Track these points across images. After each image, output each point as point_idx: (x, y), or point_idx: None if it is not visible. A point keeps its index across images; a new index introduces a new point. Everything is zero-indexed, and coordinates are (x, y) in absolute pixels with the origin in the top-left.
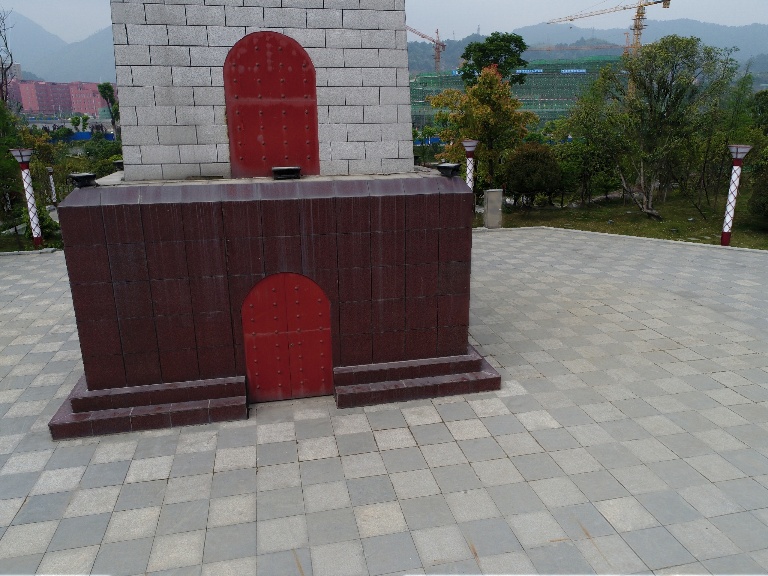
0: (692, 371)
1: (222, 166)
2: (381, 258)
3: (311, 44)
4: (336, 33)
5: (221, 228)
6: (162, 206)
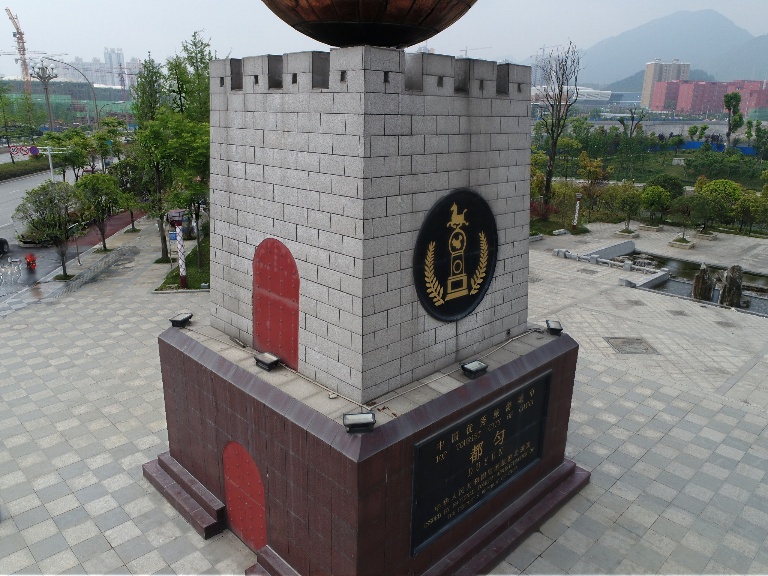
0: None
1: (249, 336)
2: (292, 476)
3: (298, 256)
4: (314, 250)
5: (212, 389)
6: (190, 358)
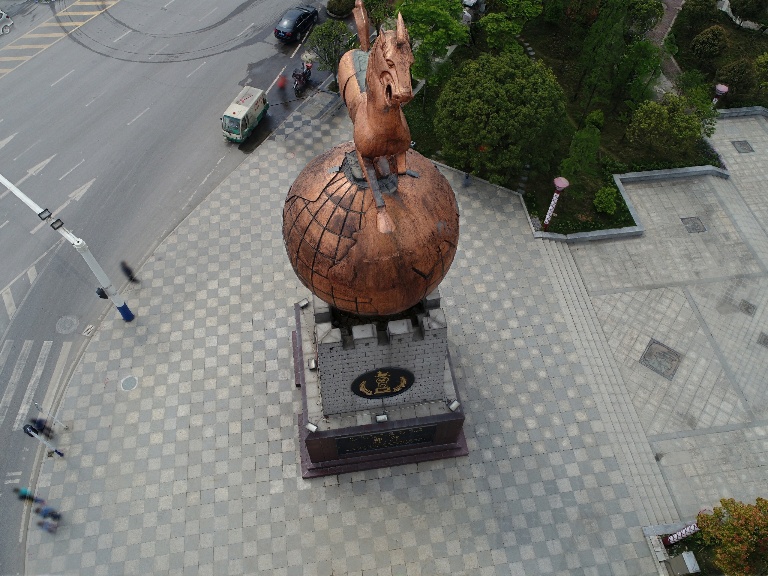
0: (306, 575)
1: None
2: None
3: None
4: None
5: None
6: None
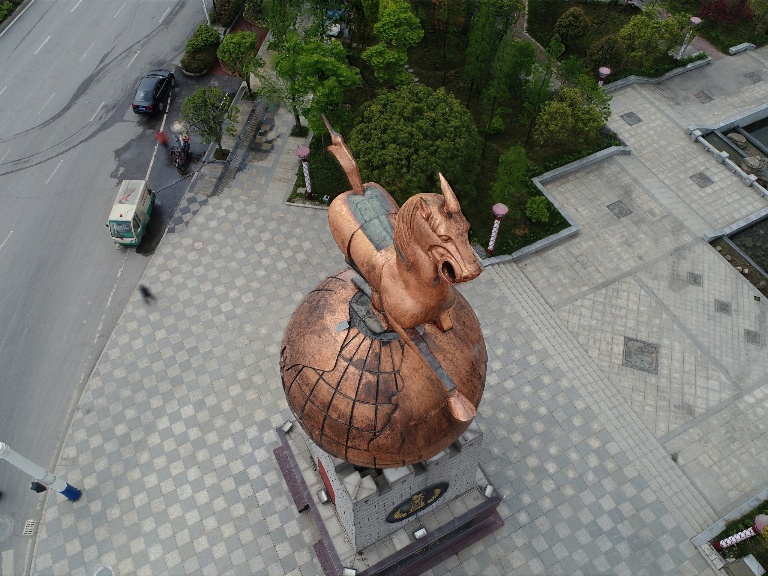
0: None
1: None
2: None
3: None
4: None
5: None
6: None
